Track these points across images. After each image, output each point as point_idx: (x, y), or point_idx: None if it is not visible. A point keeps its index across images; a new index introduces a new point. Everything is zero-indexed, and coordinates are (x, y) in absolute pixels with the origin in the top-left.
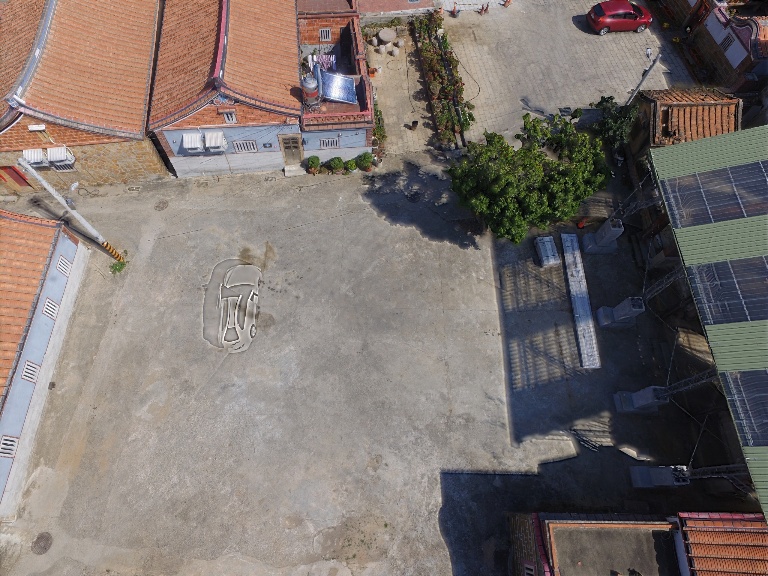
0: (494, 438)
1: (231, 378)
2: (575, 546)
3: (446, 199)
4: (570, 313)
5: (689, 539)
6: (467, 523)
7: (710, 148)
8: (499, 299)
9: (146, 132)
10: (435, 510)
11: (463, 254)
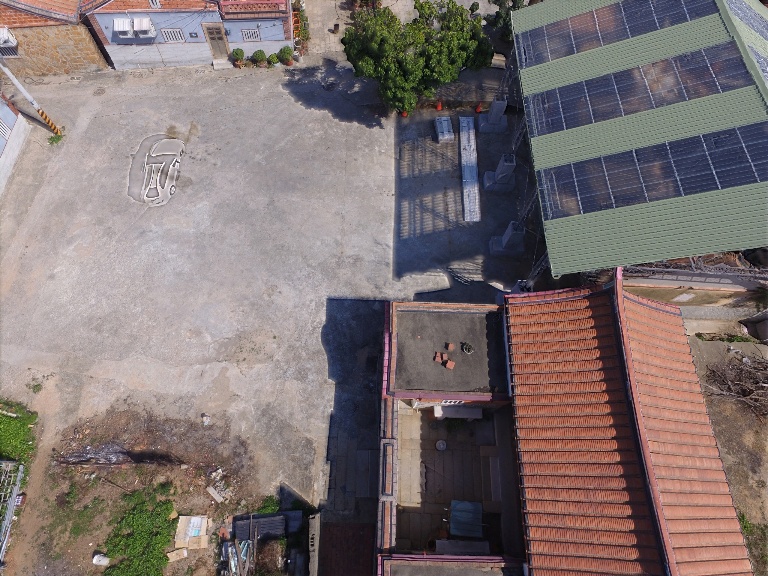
0: (378, 273)
1: (149, 226)
2: (417, 324)
3: (358, 88)
4: (459, 179)
5: (509, 312)
6: (346, 336)
7: (557, 5)
8: (397, 168)
9: (81, 18)
10: (319, 326)
11: (369, 132)
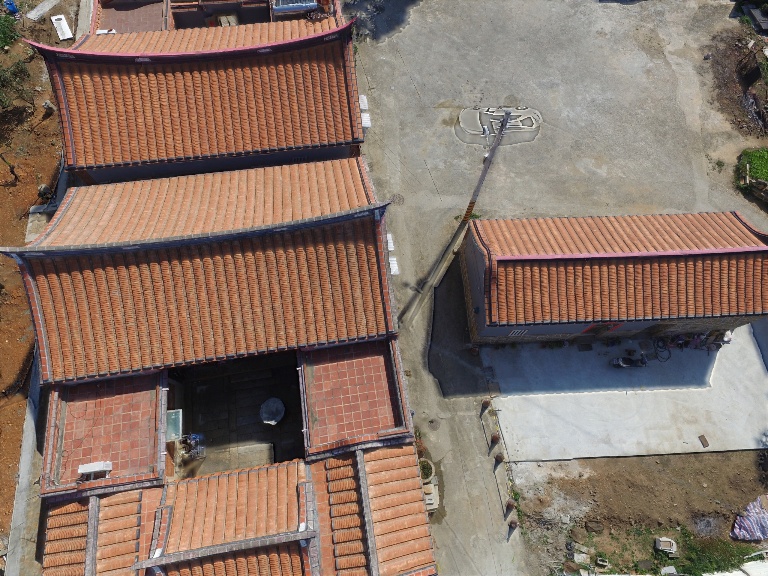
0: None
1: (563, 118)
2: None
3: None
4: None
5: None
6: None
7: None
8: None
9: None
10: (622, 6)
11: None
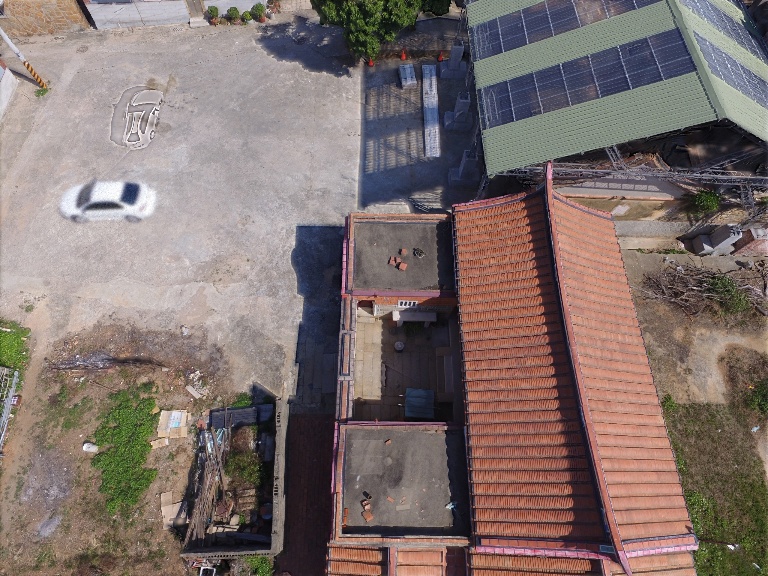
0: (344, 204)
1: (131, 166)
2: (373, 234)
3: (327, 41)
4: (421, 120)
5: (455, 219)
6: (314, 258)
7: None
8: (363, 111)
9: None
10: (289, 250)
11: (337, 81)
